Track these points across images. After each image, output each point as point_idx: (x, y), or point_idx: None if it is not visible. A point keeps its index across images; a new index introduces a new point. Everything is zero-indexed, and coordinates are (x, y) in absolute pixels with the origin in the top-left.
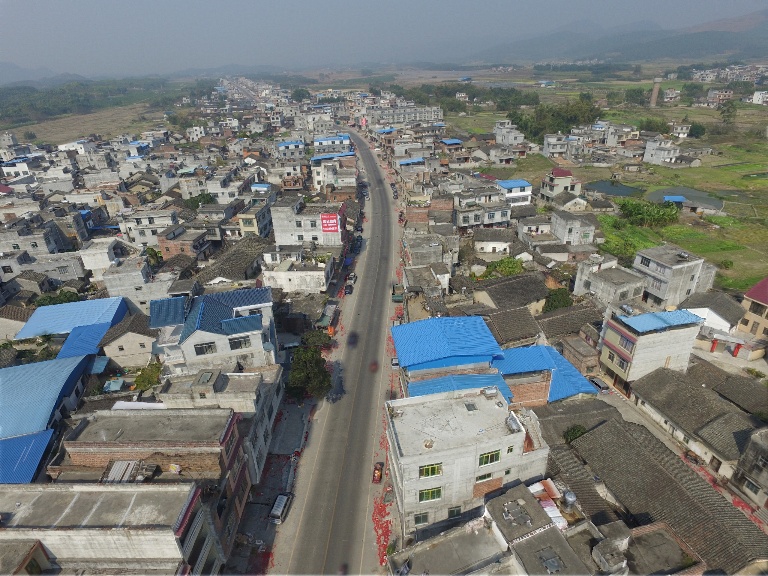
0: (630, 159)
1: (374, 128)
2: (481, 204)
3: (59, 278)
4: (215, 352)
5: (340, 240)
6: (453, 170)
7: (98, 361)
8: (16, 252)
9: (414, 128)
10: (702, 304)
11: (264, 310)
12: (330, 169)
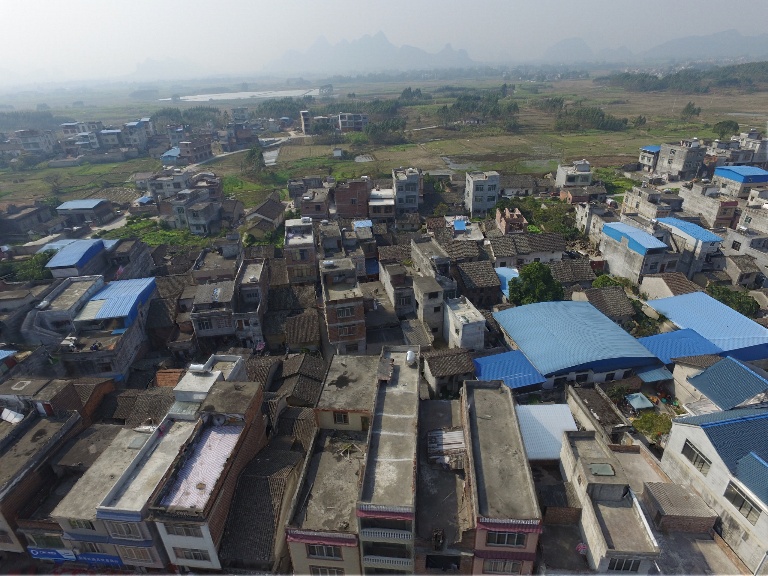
0: None
1: None
2: None
3: None
4: (704, 474)
5: None
6: None
7: (660, 371)
8: (763, 234)
9: None
10: None
11: None
12: None
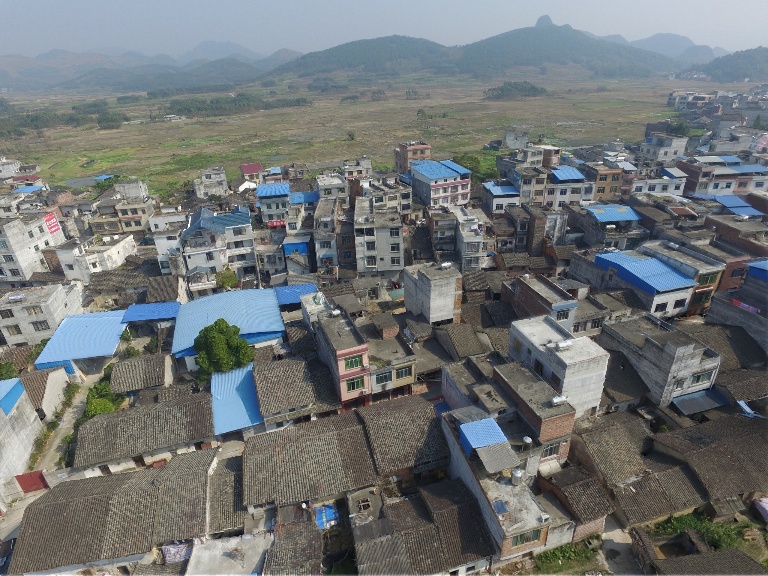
0: None
1: None
2: None
3: None
4: None
5: None
6: None
7: None
8: None
9: None
10: (243, 181)
11: None
12: None
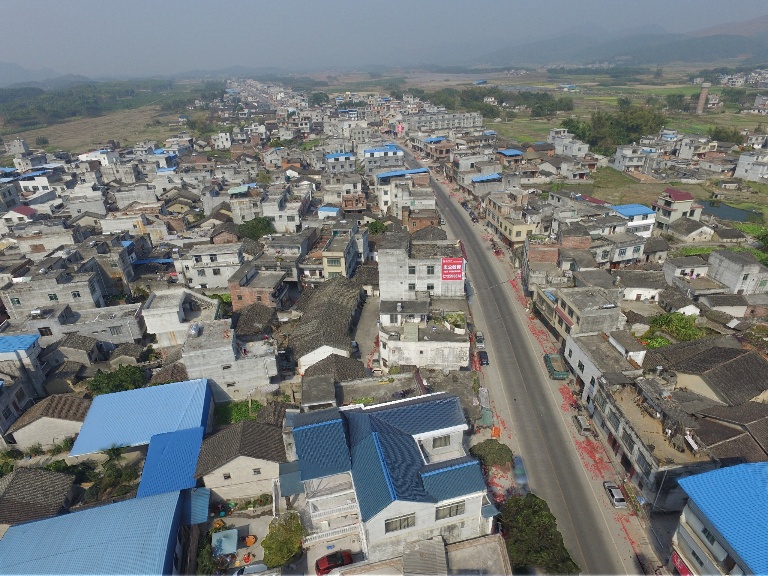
0: (719, 174)
1: (418, 136)
2: (605, 237)
3: (110, 340)
4: (412, 525)
5: (462, 290)
6: (524, 186)
7: (196, 498)
8: (56, 307)
9: (465, 137)
10: None
11: (453, 435)
12: (405, 189)
